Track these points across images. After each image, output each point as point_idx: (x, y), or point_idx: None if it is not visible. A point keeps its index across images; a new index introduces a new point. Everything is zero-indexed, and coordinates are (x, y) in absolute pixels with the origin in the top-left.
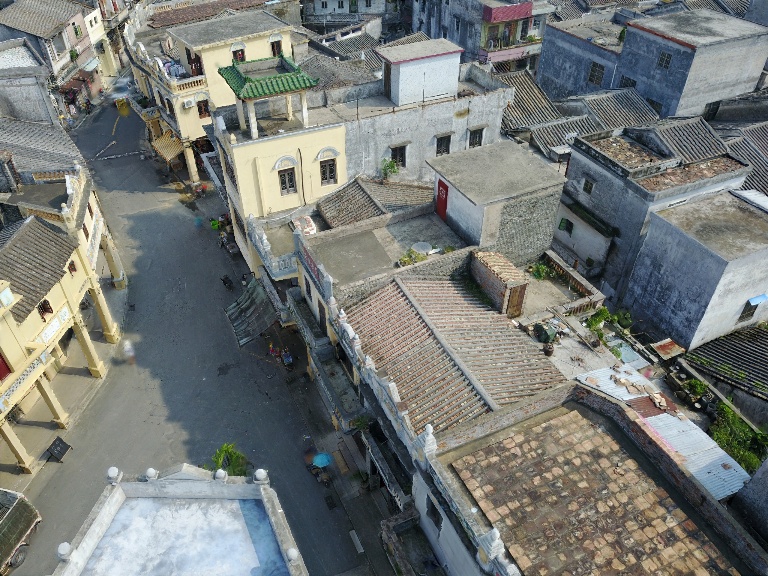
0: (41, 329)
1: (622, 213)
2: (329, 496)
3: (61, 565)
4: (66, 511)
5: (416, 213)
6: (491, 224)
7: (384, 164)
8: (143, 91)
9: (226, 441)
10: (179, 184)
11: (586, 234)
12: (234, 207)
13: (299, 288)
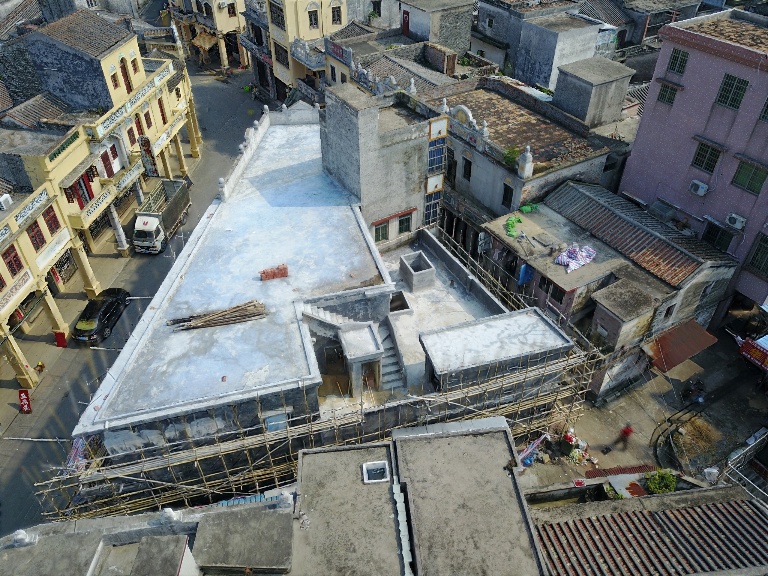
0: None
1: (509, 32)
2: None
3: (255, 130)
4: (202, 206)
5: (391, 33)
6: (435, 26)
7: (369, 13)
8: (180, 5)
9: None
10: (211, 71)
11: (492, 55)
12: (278, 43)
13: (326, 78)
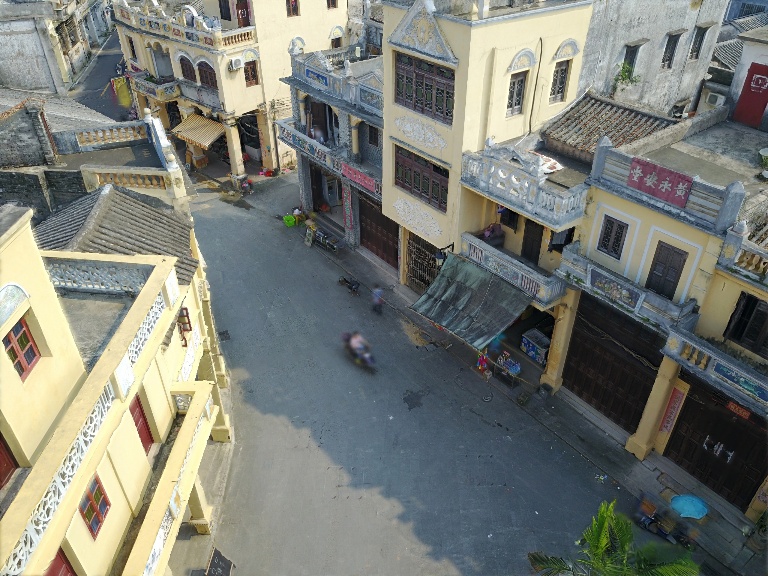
0: (182, 359)
1: None
2: (703, 564)
3: None
4: None
5: (711, 121)
6: None
7: (615, 73)
8: (148, 68)
9: (483, 506)
10: (211, 183)
11: None
12: (417, 150)
13: (578, 244)
